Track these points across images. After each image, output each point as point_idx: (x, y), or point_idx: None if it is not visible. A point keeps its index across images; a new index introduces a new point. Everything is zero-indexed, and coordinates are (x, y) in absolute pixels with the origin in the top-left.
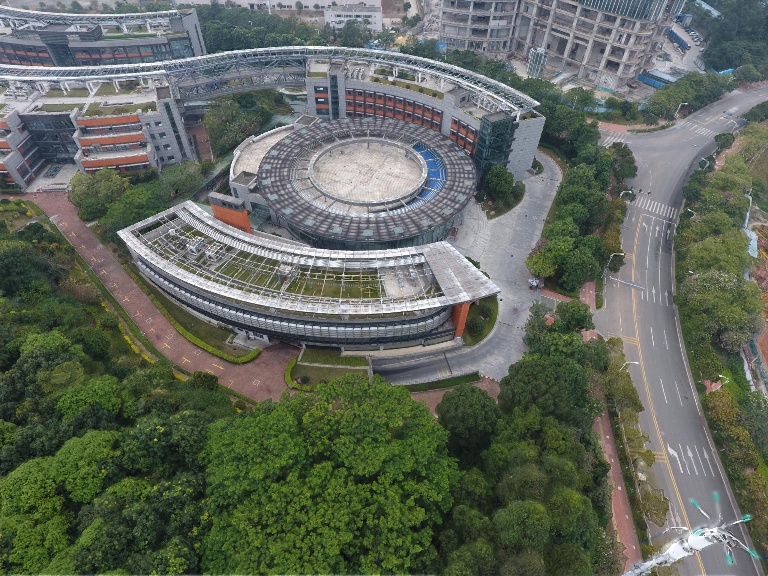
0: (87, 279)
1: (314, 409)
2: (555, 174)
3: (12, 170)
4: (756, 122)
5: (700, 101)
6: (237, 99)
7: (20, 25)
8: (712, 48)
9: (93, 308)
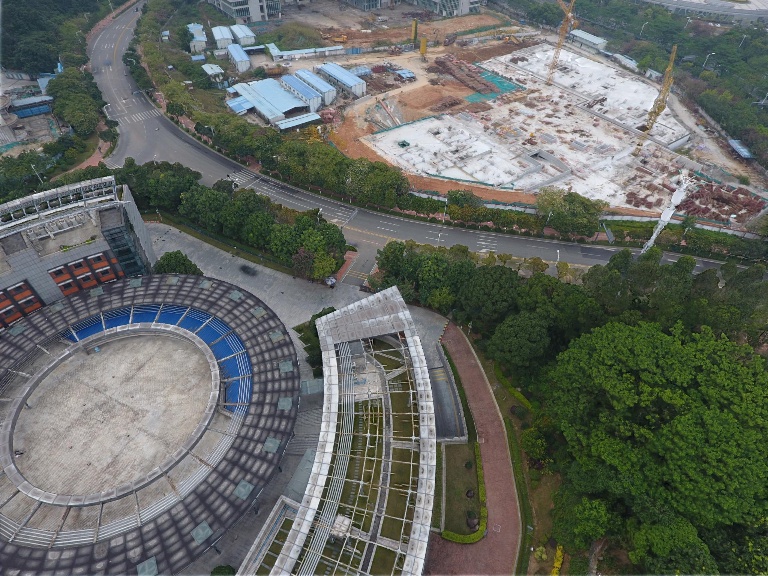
0: None
1: (665, 397)
2: (157, 228)
3: None
4: (162, 85)
5: (99, 99)
6: None
7: None
8: (6, 57)
9: None
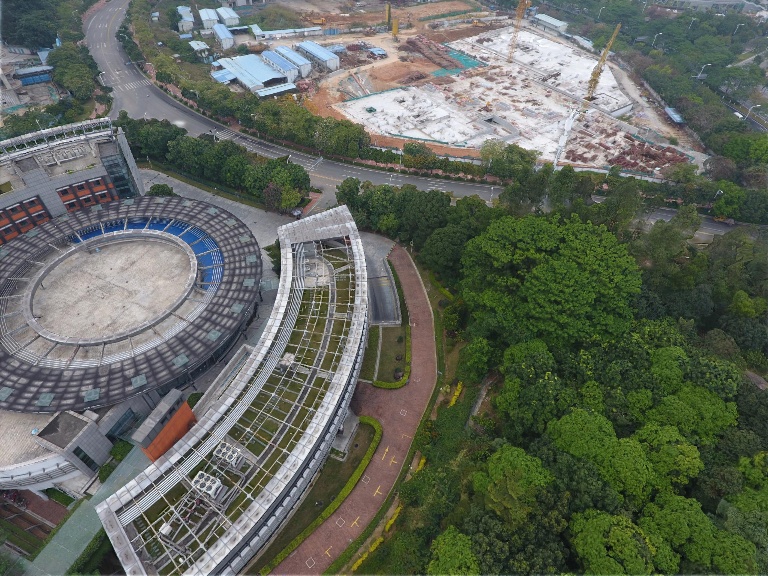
0: None
1: (529, 253)
2: (147, 173)
3: None
4: (152, 57)
5: (95, 69)
6: None
7: None
8: (8, 33)
9: None
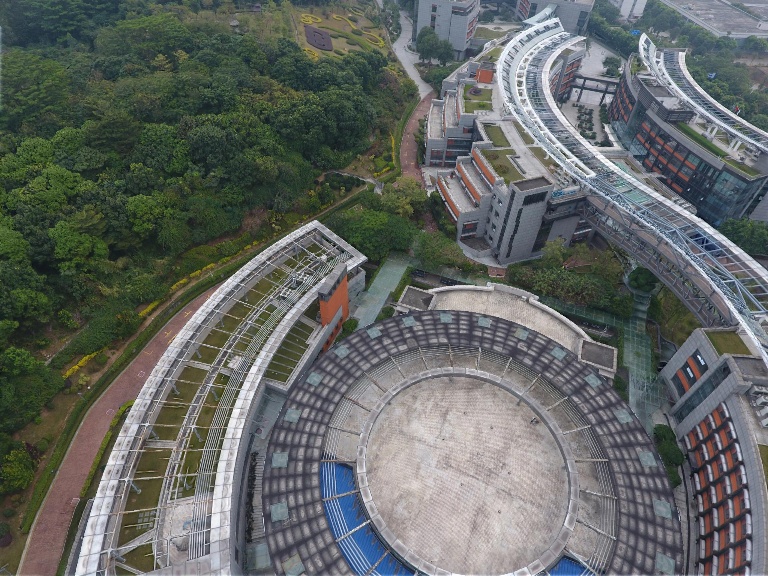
0: (293, 227)
1: None
2: None
3: (428, 148)
4: None
5: None
6: (638, 267)
7: (648, 74)
8: None
9: (247, 237)
